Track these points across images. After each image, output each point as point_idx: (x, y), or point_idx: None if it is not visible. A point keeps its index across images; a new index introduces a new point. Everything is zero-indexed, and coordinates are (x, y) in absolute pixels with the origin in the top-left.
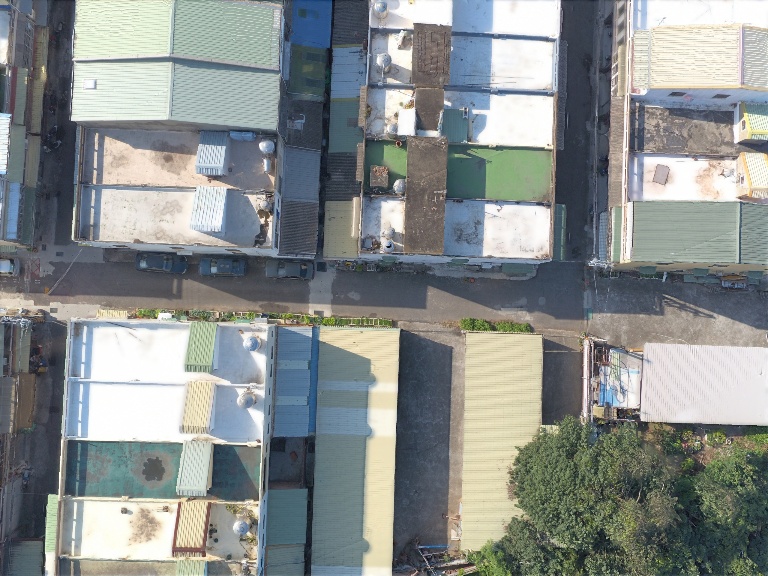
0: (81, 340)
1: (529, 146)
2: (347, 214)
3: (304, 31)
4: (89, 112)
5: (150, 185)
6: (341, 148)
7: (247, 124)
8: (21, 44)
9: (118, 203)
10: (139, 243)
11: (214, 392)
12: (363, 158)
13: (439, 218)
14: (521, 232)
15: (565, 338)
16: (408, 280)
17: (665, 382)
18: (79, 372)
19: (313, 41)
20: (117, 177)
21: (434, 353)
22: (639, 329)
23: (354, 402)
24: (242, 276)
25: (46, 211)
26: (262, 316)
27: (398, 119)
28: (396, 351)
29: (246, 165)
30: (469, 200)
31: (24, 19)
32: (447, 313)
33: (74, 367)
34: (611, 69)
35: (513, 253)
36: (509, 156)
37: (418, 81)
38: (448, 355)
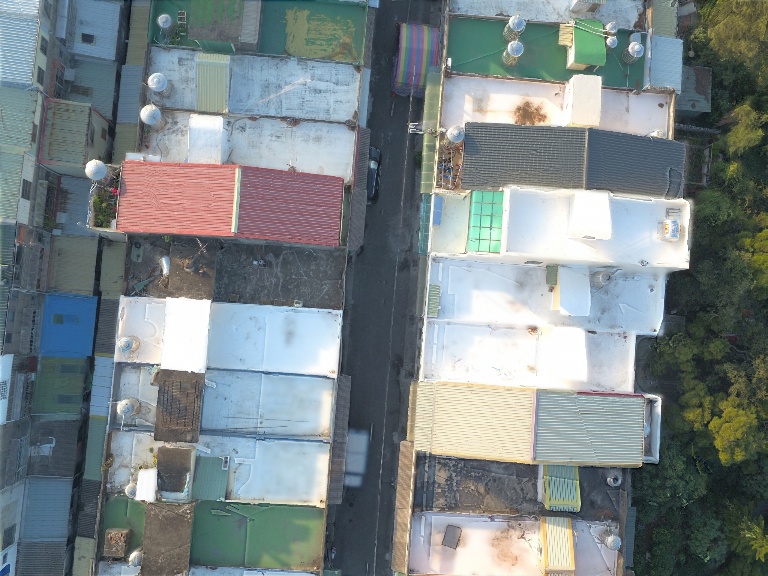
0: None
1: (297, 504)
2: None
3: (59, 340)
4: None
5: None
6: (97, 475)
7: None
8: None
9: None
10: None
11: None
12: (98, 521)
13: None
14: None
15: None
16: None
17: None
18: None
19: (70, 350)
20: None
21: None
22: None
23: None
24: None
25: None
26: None
27: (137, 481)
28: None
29: None
30: (225, 567)
31: None
32: None
33: None
34: None
35: None
36: (275, 513)
37: (161, 438)
38: None
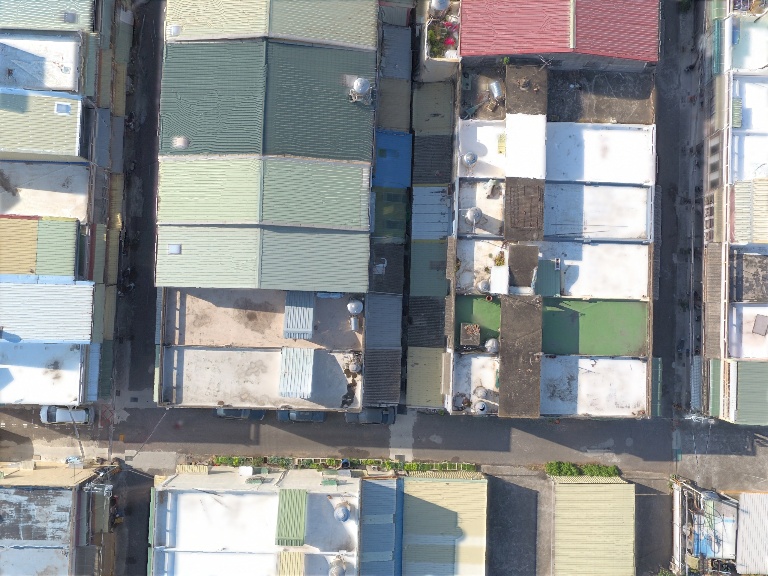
0: (165, 507)
1: (624, 298)
2: (431, 361)
3: (385, 172)
4: (174, 278)
5: (234, 346)
6: (423, 292)
7: (337, 288)
8: (99, 199)
9: (201, 364)
10: (224, 408)
11: (304, 563)
12: (453, 315)
13: (535, 380)
14: (616, 387)
15: (654, 480)
16: (491, 422)
17: (762, 533)
18: (164, 540)
19: (394, 181)
20: (200, 337)
21: (519, 498)
22: (730, 470)
23: (441, 557)
24: (321, 422)
25: (120, 356)
26: (343, 464)
27: (490, 277)
28: (483, 504)
29: (332, 322)
30: (562, 355)
31: (102, 173)
32: (531, 456)
33: (158, 535)
34: (704, 209)
35: (608, 410)
36: (603, 308)
37: (511, 237)
38: (533, 499)
